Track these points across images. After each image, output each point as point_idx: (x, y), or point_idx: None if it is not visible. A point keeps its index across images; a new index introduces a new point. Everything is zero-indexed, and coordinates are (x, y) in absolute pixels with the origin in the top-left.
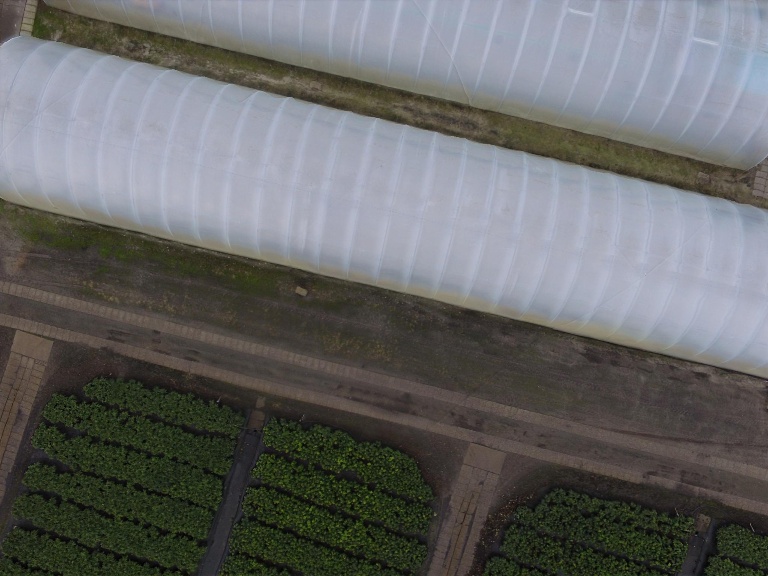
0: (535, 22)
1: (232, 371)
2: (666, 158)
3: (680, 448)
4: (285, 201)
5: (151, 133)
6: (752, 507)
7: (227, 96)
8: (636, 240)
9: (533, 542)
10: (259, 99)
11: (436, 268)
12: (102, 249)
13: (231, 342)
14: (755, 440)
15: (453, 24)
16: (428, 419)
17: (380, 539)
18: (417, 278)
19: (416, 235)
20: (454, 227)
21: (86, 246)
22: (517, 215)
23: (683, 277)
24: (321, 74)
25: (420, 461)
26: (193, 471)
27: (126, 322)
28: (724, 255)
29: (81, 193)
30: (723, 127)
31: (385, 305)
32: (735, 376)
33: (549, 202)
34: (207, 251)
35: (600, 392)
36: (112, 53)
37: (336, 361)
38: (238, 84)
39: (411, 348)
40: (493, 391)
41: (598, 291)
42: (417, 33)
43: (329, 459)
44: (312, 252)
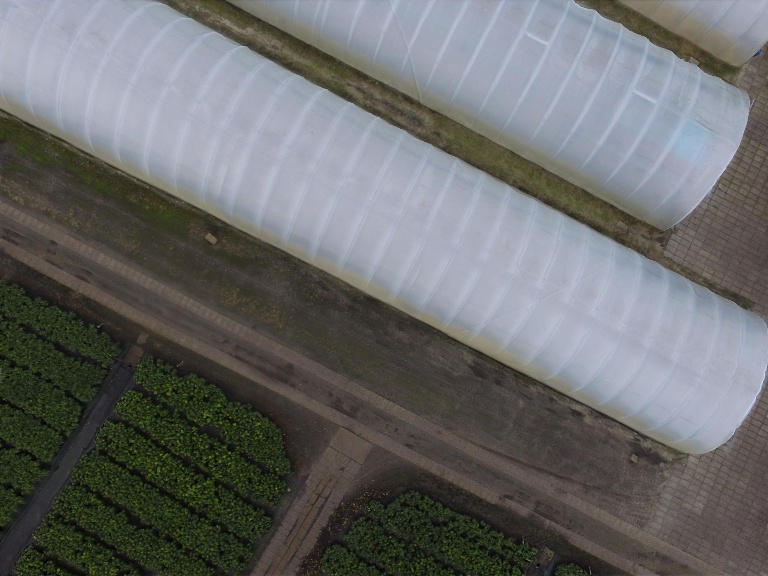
0: (492, 36)
1: (121, 300)
2: (592, 200)
3: (541, 478)
4: (209, 142)
5: (92, 41)
6: (595, 551)
7: (181, 27)
8: (537, 265)
9: (377, 538)
10: (212, 39)
11: (343, 245)
12: (20, 147)
13: (127, 271)
14: (612, 487)
15: (416, 17)
16: (305, 394)
17: (227, 502)
18: (324, 251)
19: (330, 207)
20: (368, 209)
21: (4, 140)
22: (431, 212)
23: (573, 311)
24: (285, 35)
25: (287, 433)
26: (54, 391)
27: (25, 225)
28: (616, 299)
29: (8, 83)
30: (646, 182)
31: (291, 272)
32: (608, 421)
33: (465, 208)
34: (127, 176)
35: (478, 407)
36: None
37: (228, 315)
38: (200, 22)
39: (306, 320)
40: (375, 381)
41: (491, 305)
42: (380, 17)
43: (196, 410)
44: (227, 200)
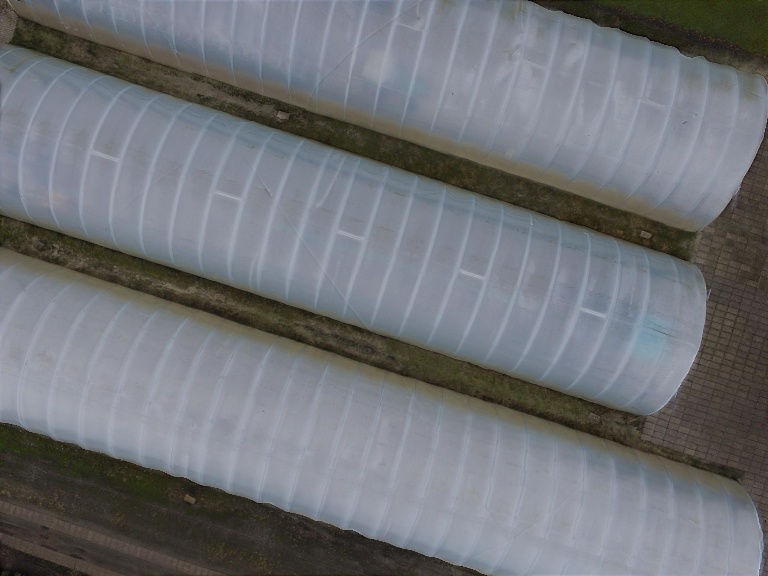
0: (426, 281)
1: (116, 572)
2: (559, 396)
3: None
4: (167, 437)
5: (39, 363)
6: None
7: (122, 321)
8: (506, 504)
9: None
10: (153, 326)
11: (313, 508)
12: None
13: (117, 544)
14: None
15: (347, 274)
16: None
17: None
18: (297, 509)
19: (293, 480)
20: (330, 477)
21: None
22: (392, 471)
23: (549, 544)
24: (226, 287)
25: None
26: None
27: (16, 516)
28: (592, 525)
29: None
30: (608, 388)
31: (271, 519)
32: None
33: (425, 459)
34: (100, 453)
35: None
36: (21, 251)
37: (218, 570)
38: (143, 291)
39: (293, 563)
40: None
41: (467, 547)
42: (312, 277)
43: None
44: (195, 478)
